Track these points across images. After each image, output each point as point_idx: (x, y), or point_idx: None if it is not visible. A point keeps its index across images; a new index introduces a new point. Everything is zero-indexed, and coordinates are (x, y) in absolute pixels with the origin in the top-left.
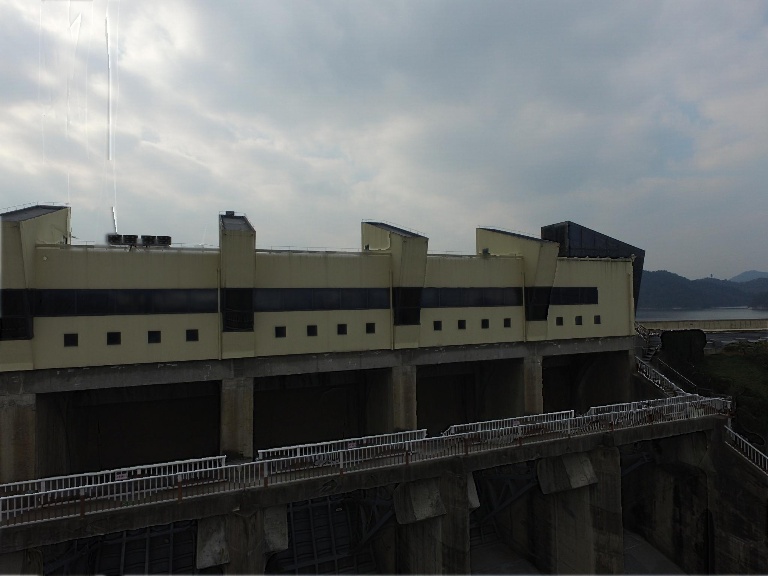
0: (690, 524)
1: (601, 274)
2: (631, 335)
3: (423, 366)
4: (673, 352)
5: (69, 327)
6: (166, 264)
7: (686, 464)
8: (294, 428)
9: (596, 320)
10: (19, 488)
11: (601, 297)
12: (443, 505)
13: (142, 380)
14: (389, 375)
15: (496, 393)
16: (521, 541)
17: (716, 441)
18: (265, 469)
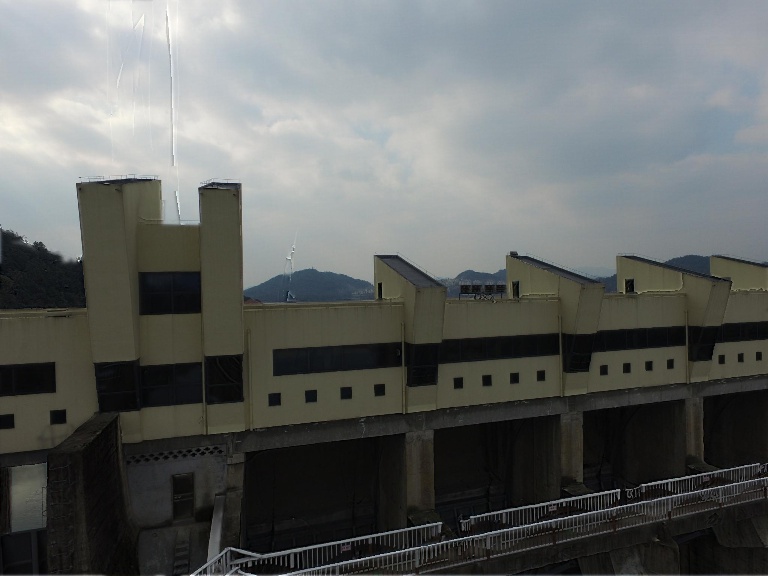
0: None
1: None
2: None
3: None
4: None
5: (456, 372)
6: (521, 313)
7: None
8: None
9: None
10: (489, 518)
11: None
12: None
13: (504, 416)
14: (678, 406)
15: (741, 417)
16: None
17: None
18: (670, 504)
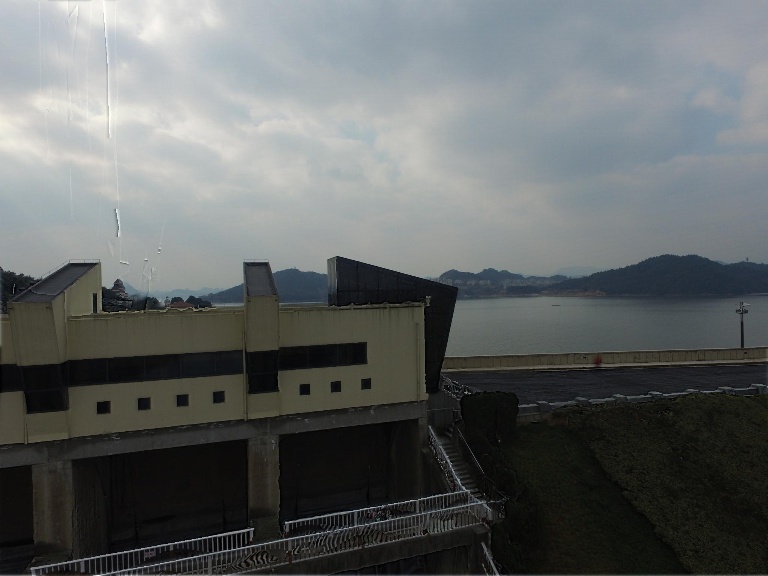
0: None
1: (373, 325)
2: (419, 400)
3: (85, 459)
4: (469, 424)
5: None
6: None
7: None
8: (15, 508)
9: (364, 384)
10: None
11: (373, 355)
12: None
13: None
14: None
15: None
16: None
17: (473, 561)
18: None
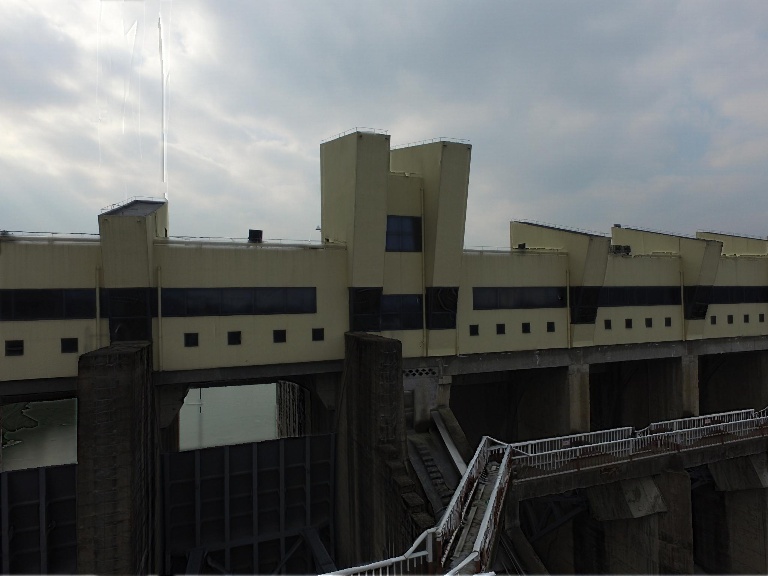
0: None
1: None
2: None
3: None
4: None
5: (606, 315)
6: (653, 267)
7: None
8: None
9: None
10: (664, 426)
11: None
12: None
13: (641, 355)
14: (765, 356)
15: None
16: None
17: None
18: None
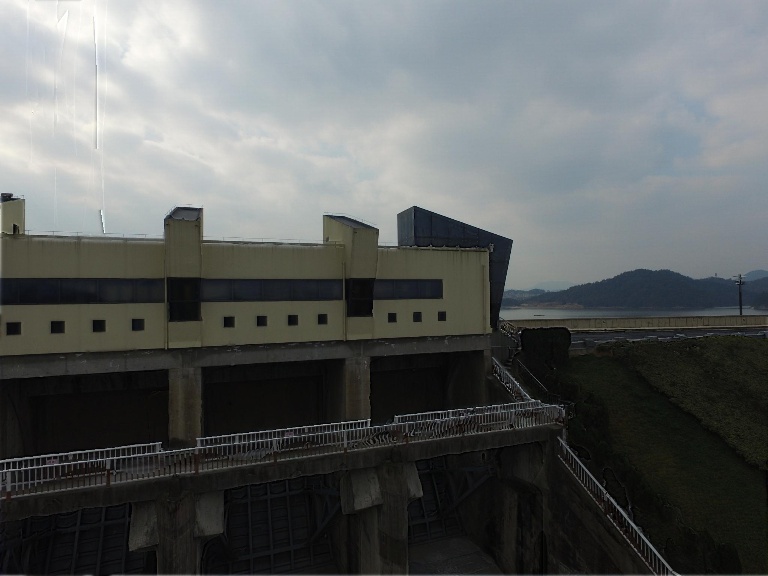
0: (529, 547)
1: (448, 265)
2: (485, 333)
3: (212, 368)
4: (530, 352)
5: None
6: None
7: (521, 480)
8: (111, 435)
9: (440, 316)
10: None
11: (447, 291)
12: (157, 533)
13: None
14: None
15: (332, 398)
16: (344, 564)
17: (550, 454)
18: None
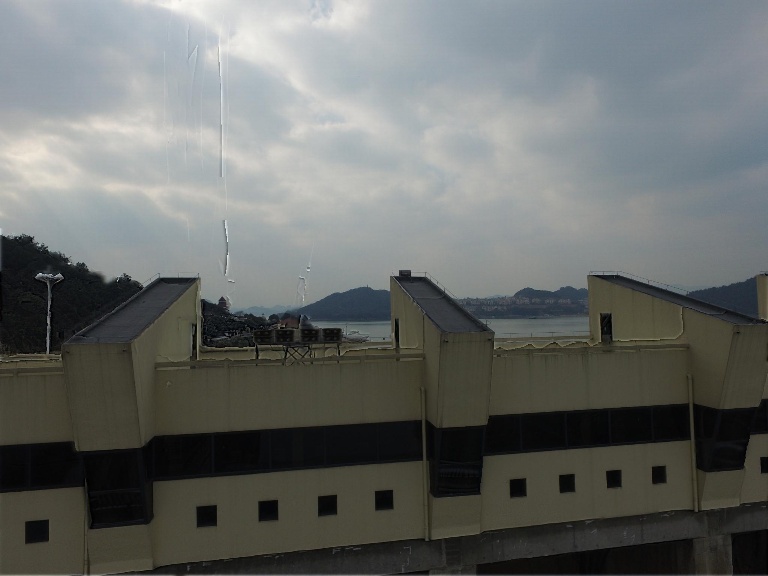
0: None
1: None
2: None
3: None
4: None
5: (204, 495)
6: (344, 384)
7: None
8: None
9: None
10: None
11: None
12: None
13: (309, 575)
14: (682, 547)
15: None
16: None
17: None
18: None
